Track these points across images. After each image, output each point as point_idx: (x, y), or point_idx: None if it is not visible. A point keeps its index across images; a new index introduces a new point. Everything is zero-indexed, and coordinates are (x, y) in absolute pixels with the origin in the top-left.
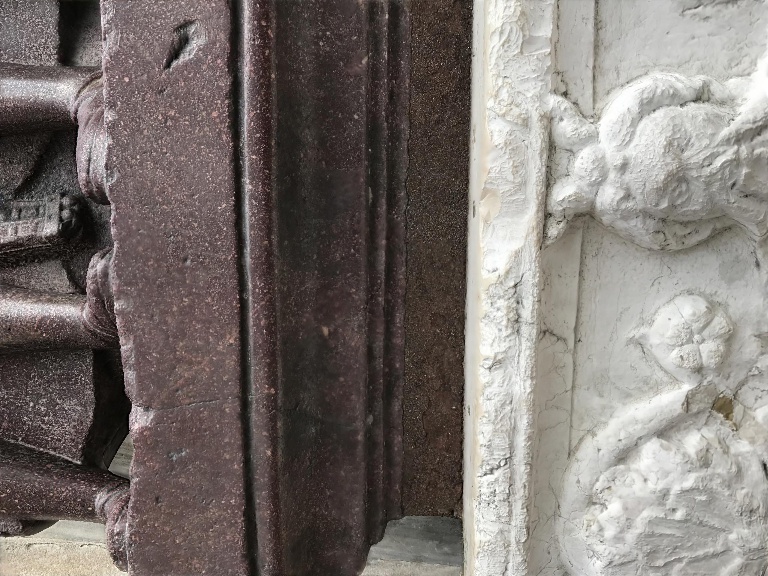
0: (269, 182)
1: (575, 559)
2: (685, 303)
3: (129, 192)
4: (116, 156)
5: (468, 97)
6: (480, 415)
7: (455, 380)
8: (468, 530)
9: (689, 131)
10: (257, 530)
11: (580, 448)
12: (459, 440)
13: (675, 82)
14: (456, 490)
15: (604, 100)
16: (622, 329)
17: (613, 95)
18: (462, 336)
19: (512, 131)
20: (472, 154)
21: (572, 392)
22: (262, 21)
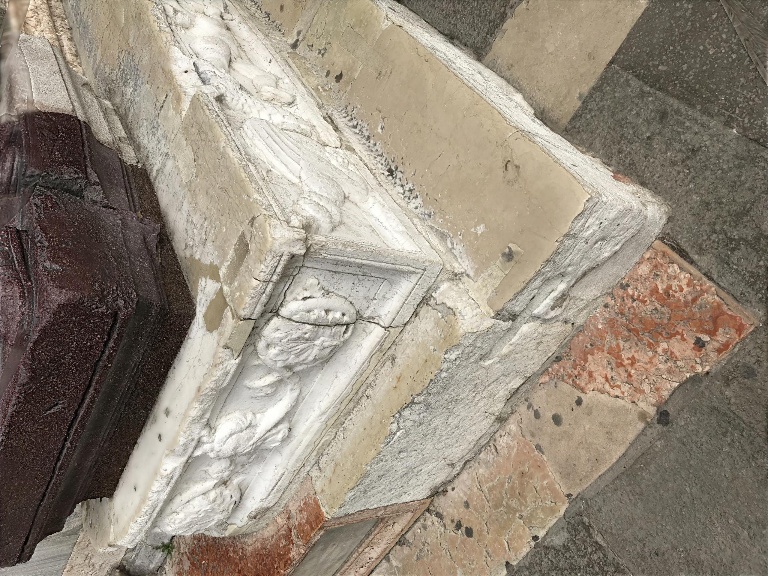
0: (78, 442)
1: (162, 526)
2: (224, 462)
3: (7, 452)
4: (5, 442)
5: (164, 379)
6: (145, 504)
7: (124, 461)
8: (122, 521)
9: (241, 443)
10: (29, 539)
11: (175, 499)
12: (118, 478)
13: (242, 424)
14: (111, 492)
15: (219, 421)
16: (201, 467)
17: (222, 421)
18: (133, 448)
19: (187, 441)
20: (162, 409)
21: (177, 485)
22: (95, 398)
